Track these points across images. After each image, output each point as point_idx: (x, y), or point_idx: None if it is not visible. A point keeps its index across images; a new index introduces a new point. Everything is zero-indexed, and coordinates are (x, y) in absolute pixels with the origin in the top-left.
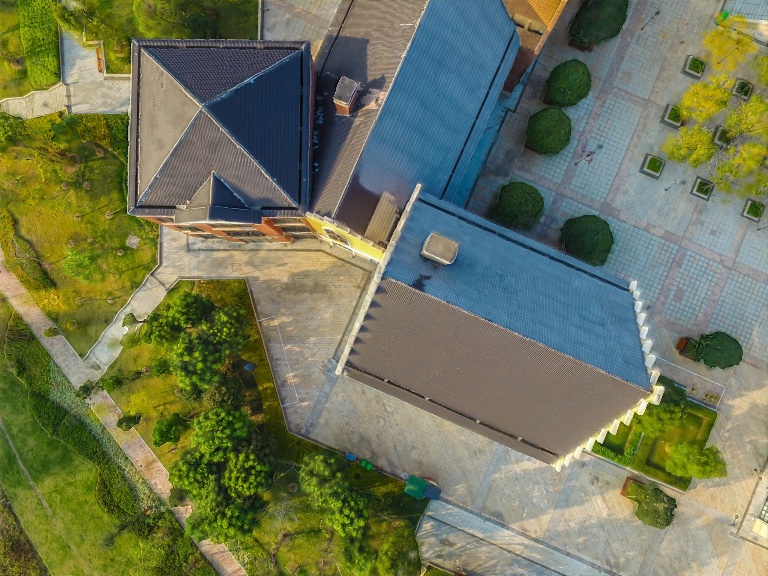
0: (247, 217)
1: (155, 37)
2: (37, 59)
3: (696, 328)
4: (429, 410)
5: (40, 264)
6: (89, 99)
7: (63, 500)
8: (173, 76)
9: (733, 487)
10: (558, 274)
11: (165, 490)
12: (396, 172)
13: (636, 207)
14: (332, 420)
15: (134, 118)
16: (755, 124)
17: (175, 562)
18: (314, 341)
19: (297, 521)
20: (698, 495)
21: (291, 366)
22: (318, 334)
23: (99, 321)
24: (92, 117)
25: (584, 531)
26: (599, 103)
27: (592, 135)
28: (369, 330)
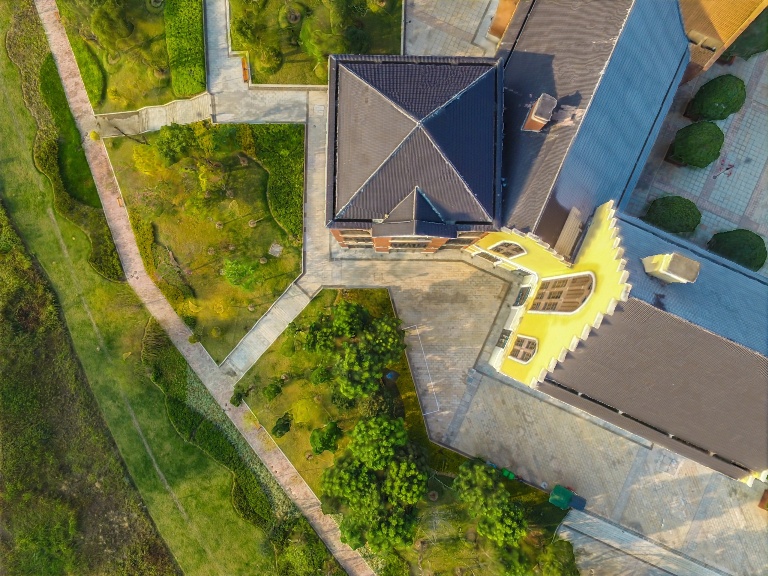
0: (445, 231)
1: (322, 50)
2: (183, 69)
3: None
4: (618, 424)
5: (179, 271)
6: (233, 108)
7: (199, 505)
8: (380, 92)
9: None
10: (759, 291)
11: (299, 496)
12: (584, 188)
13: None
14: (472, 429)
15: (332, 132)
16: None
17: (310, 568)
18: (455, 351)
19: (453, 530)
20: None
21: (432, 375)
22: (459, 344)
23: (238, 328)
24: (238, 126)
25: (722, 543)
26: (738, 117)
27: (731, 149)
28: (585, 346)
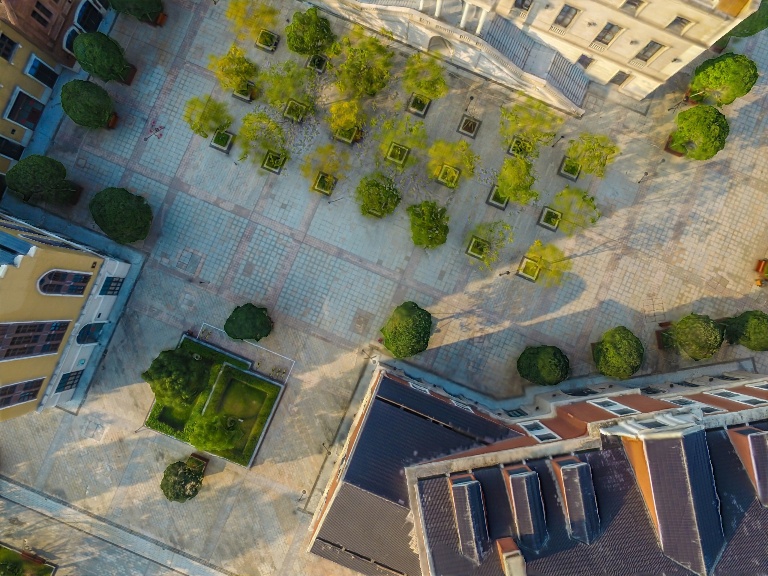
0: None
1: None
2: None
3: (265, 302)
4: None
5: None
6: None
7: None
8: None
9: (301, 462)
10: None
11: None
12: None
13: (206, 182)
14: None
15: None
16: (330, 97)
17: None
18: None
19: None
20: (265, 470)
21: None
22: None
23: None
24: None
25: (148, 508)
26: (170, 78)
27: (163, 110)
28: None
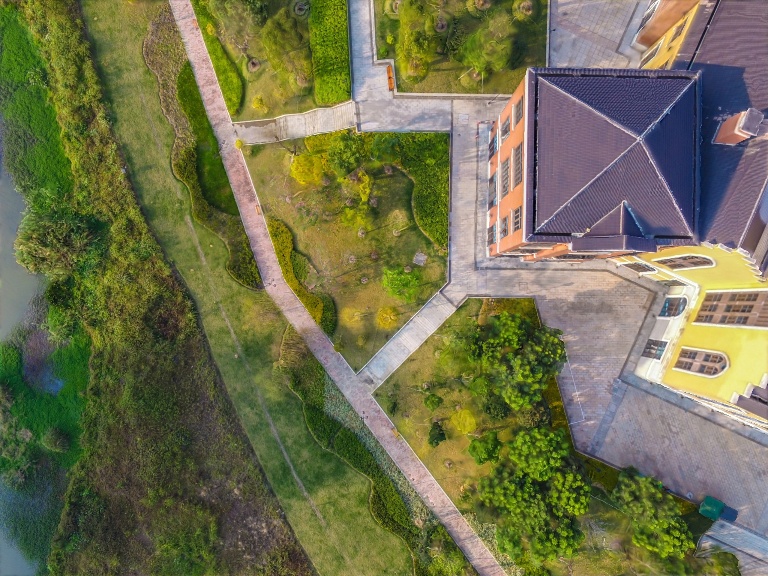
0: (648, 246)
1: None
2: (329, 77)
3: None
4: None
5: None
6: (378, 117)
7: (337, 512)
8: (590, 106)
9: None
10: None
11: (437, 504)
12: None
13: None
14: (618, 439)
15: (531, 146)
16: None
17: (448, 575)
18: (600, 360)
19: (613, 541)
20: None
21: (577, 385)
22: (604, 354)
23: (379, 336)
24: (384, 135)
25: None
26: None
27: None
28: None
